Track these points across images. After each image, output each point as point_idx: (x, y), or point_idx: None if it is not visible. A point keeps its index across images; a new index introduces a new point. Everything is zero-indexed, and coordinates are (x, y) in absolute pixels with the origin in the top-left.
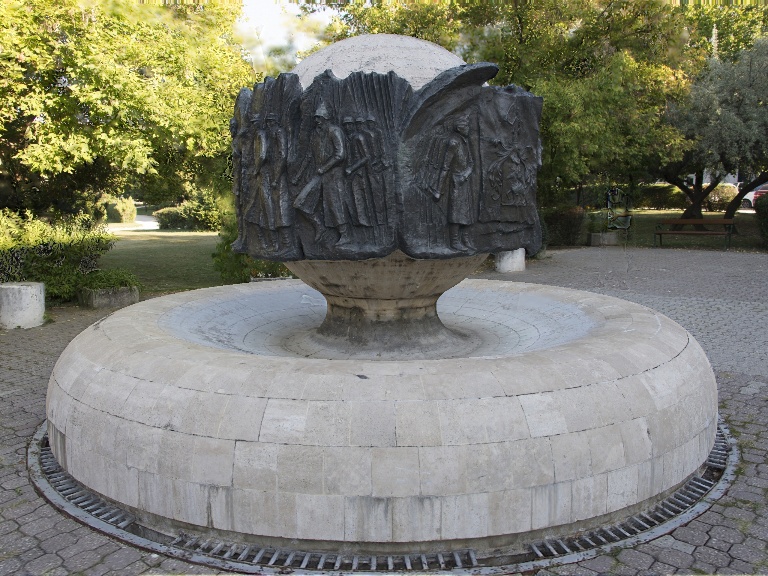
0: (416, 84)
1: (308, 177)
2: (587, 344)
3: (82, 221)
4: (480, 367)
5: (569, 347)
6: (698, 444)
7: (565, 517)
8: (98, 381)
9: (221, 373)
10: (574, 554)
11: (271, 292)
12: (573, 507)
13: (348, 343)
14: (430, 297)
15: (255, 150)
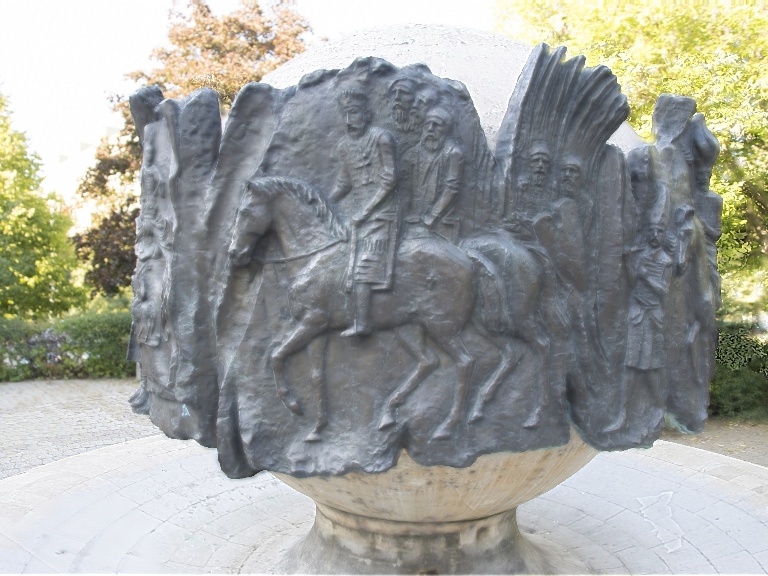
0: None
1: None
2: None
3: None
4: None
5: None
6: None
7: None
8: None
9: None
10: None
11: (643, 466)
12: None
13: None
14: None
15: None
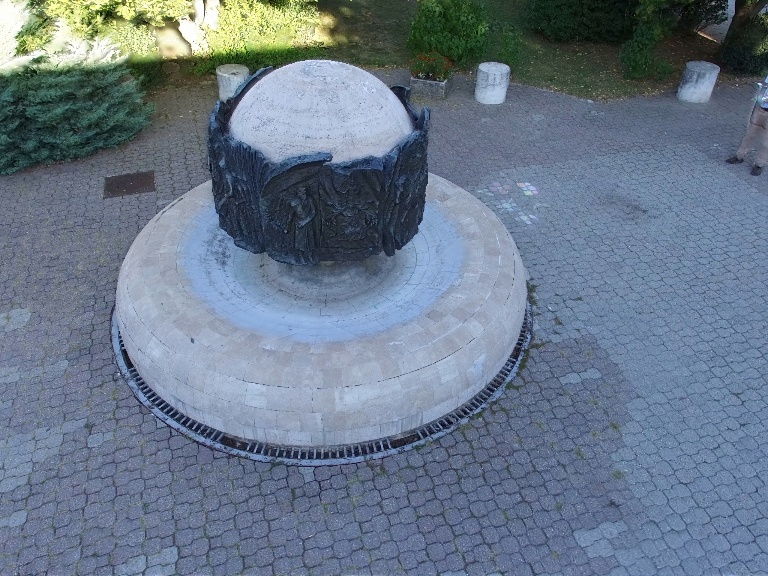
0: (286, 151)
1: None
2: (340, 352)
3: (295, 2)
4: (248, 356)
5: (325, 351)
6: (379, 429)
7: (263, 439)
8: (122, 278)
9: (149, 308)
10: (262, 456)
11: None
12: (267, 437)
13: (285, 266)
14: None
15: None
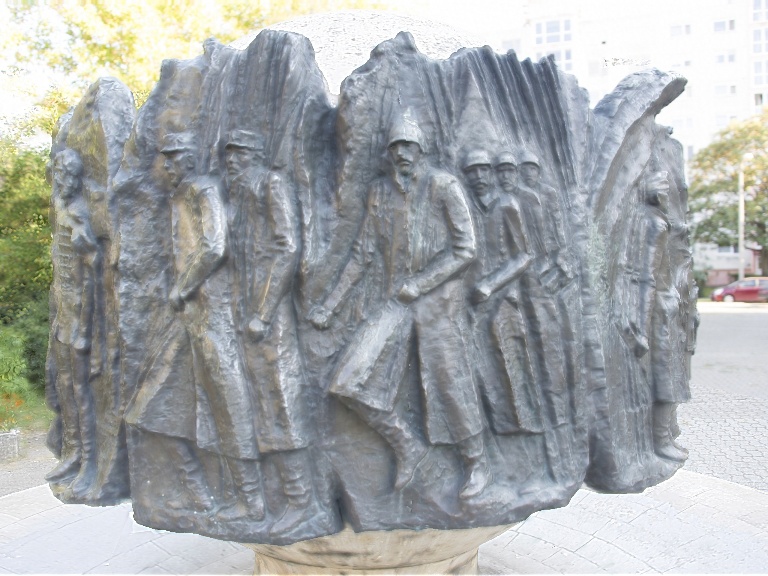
0: None
1: (363, 306)
2: None
3: None
4: None
5: None
6: None
7: None
8: None
9: None
10: None
11: (64, 519)
12: None
13: None
14: None
15: (176, 231)
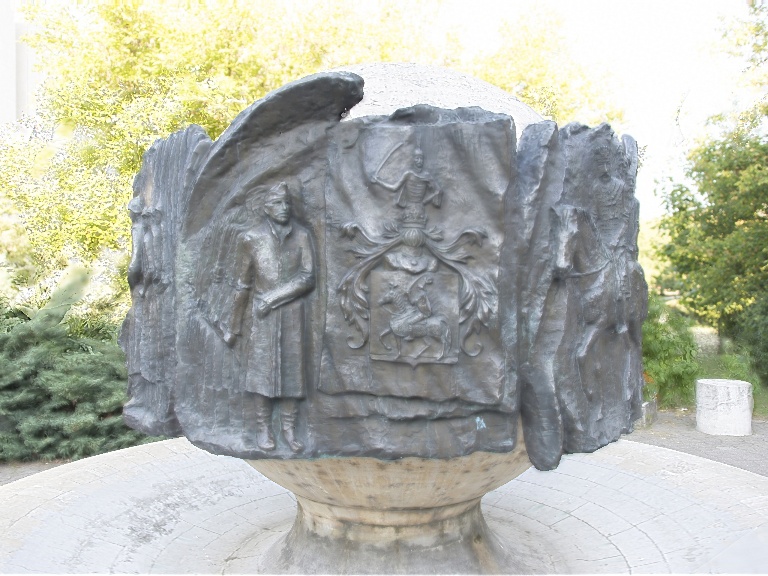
0: None
1: None
2: None
3: None
4: None
5: None
6: None
7: None
8: None
9: None
10: None
11: None
12: None
13: (278, 556)
14: (396, 510)
15: None
